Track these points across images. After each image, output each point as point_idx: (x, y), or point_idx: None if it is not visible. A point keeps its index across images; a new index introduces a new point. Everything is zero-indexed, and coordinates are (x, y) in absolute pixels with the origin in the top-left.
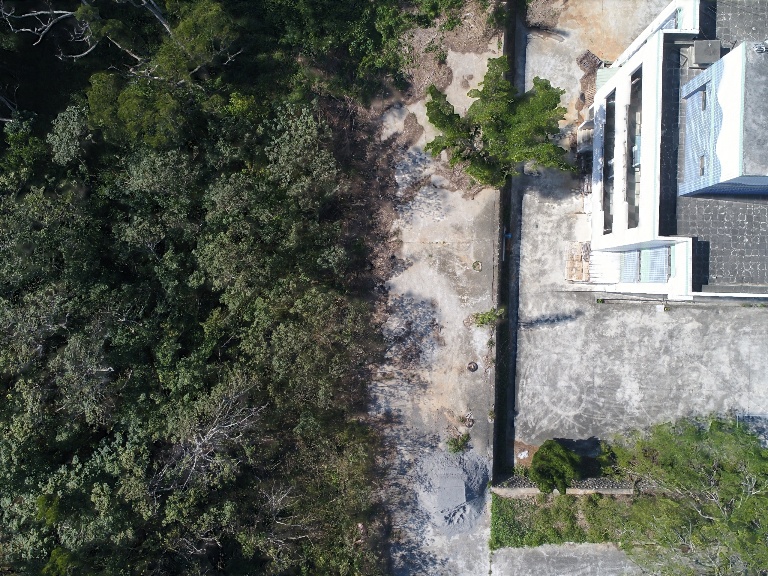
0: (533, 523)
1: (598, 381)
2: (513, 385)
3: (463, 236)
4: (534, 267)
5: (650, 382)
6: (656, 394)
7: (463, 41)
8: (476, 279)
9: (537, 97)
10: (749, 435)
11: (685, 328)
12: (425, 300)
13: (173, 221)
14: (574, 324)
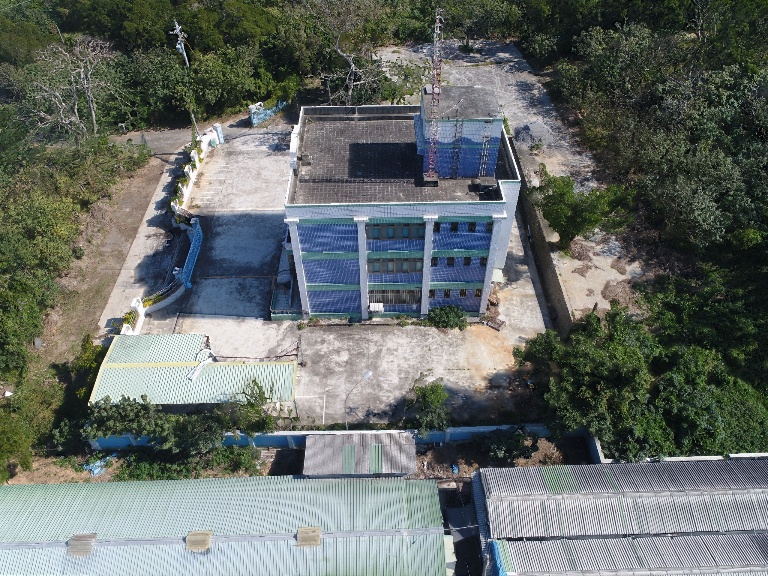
0: None
1: None
2: None
3: None
4: None
5: None
6: None
7: (602, 314)
8: None
9: (567, 200)
10: None
11: None
12: None
13: (759, 159)
14: None
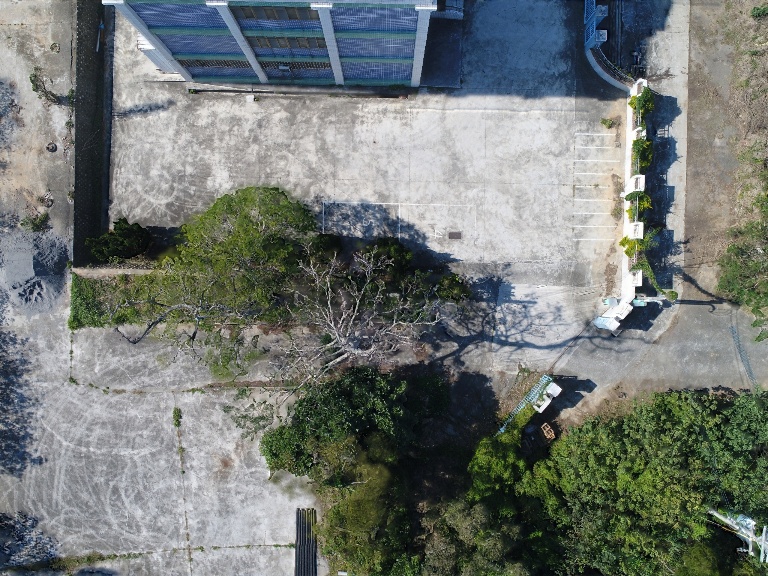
0: (114, 303)
1: (189, 170)
2: (107, 174)
3: (41, 18)
4: (127, 58)
5: (240, 170)
6: (245, 182)
7: None
8: (54, 61)
9: None
10: (335, 221)
11: (273, 118)
12: (4, 81)
13: None
14: (166, 114)
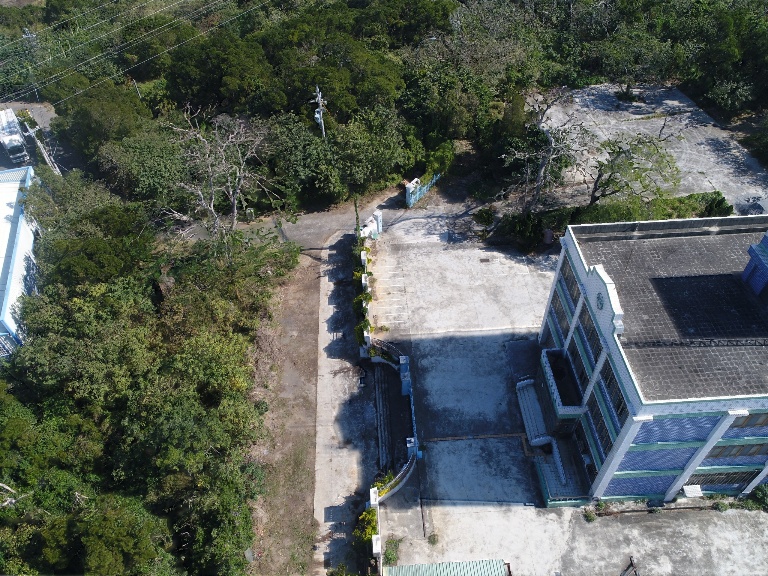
0: None
1: None
2: None
3: None
4: None
5: None
6: None
7: None
8: None
9: None
10: None
11: None
12: None
13: None
14: None
